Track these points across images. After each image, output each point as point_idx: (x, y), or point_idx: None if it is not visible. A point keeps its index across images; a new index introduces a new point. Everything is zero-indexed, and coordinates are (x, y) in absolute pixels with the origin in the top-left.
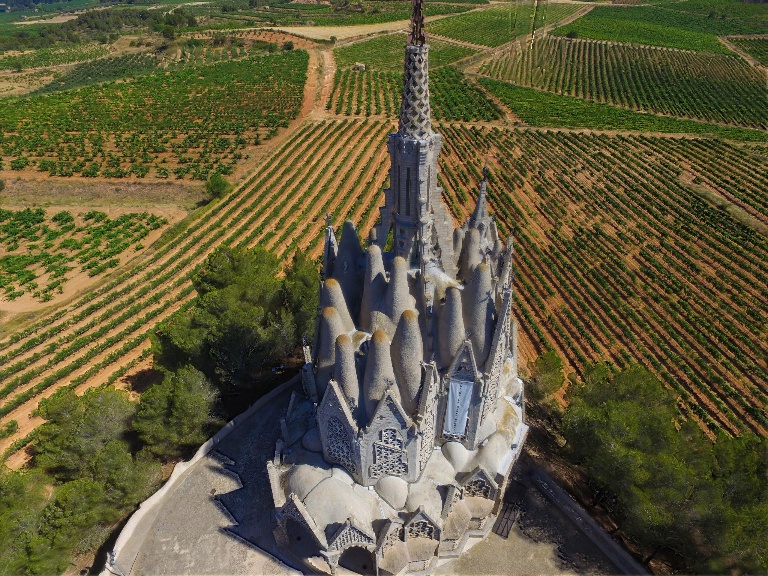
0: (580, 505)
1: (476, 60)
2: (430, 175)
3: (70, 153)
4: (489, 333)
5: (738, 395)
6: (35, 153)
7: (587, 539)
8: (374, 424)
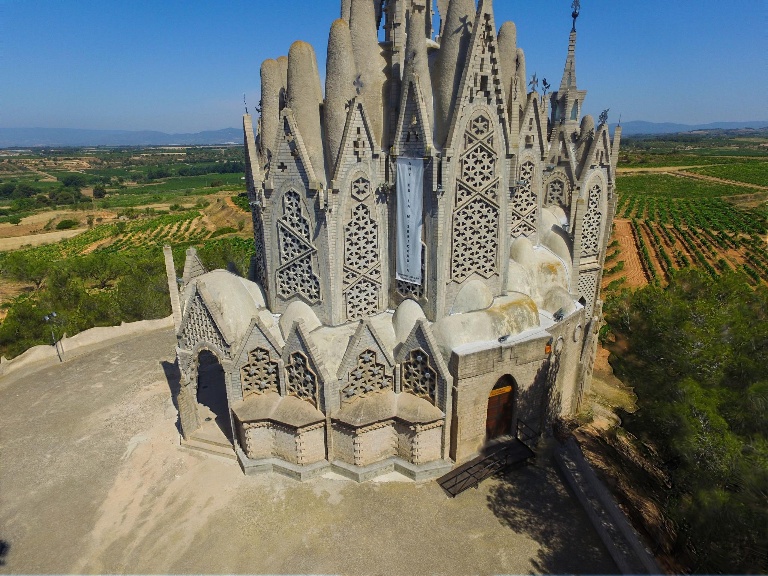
0: (632, 523)
1: (758, 198)
2: None
3: None
4: None
5: None
6: None
7: (613, 568)
8: (275, 179)
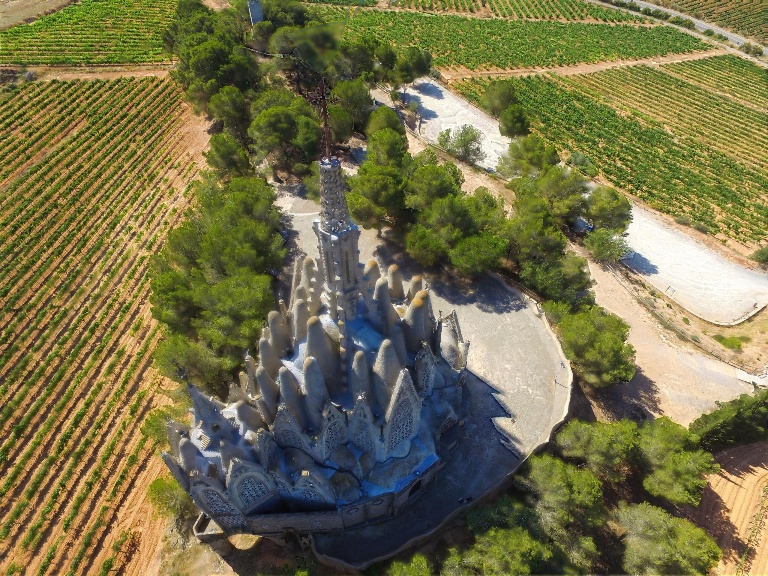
0: None
1: None
2: None
3: None
4: None
5: (3, 450)
6: None
7: None
8: None
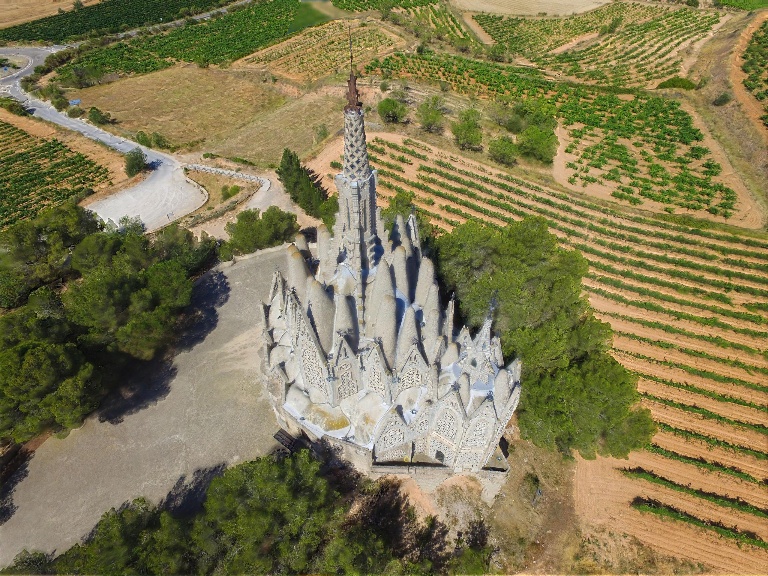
0: None
1: None
2: (349, 207)
3: None
4: None
5: None
6: None
7: None
8: None
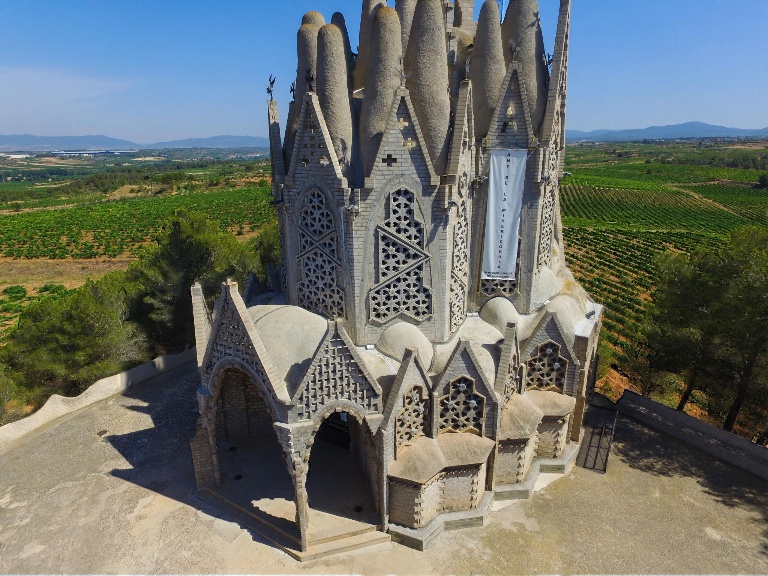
0: None
1: None
2: None
3: (42, 243)
4: (542, 79)
5: None
6: (5, 245)
7: (740, 470)
8: (377, 176)
